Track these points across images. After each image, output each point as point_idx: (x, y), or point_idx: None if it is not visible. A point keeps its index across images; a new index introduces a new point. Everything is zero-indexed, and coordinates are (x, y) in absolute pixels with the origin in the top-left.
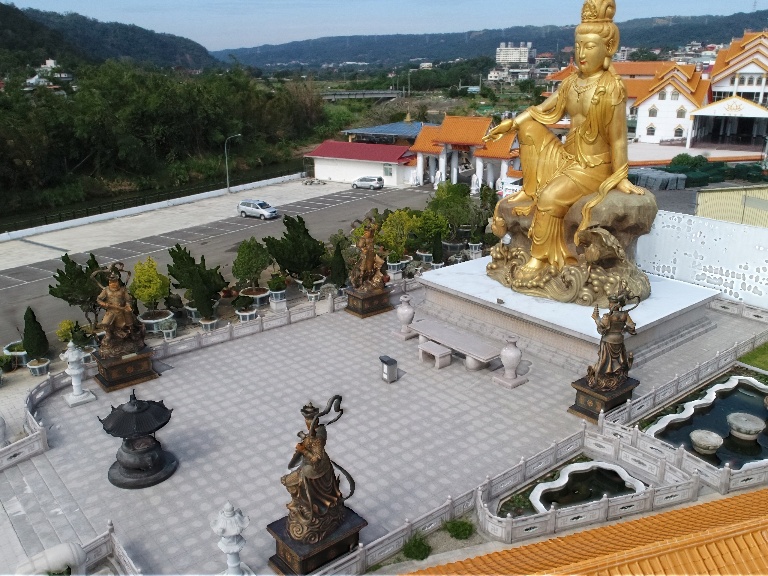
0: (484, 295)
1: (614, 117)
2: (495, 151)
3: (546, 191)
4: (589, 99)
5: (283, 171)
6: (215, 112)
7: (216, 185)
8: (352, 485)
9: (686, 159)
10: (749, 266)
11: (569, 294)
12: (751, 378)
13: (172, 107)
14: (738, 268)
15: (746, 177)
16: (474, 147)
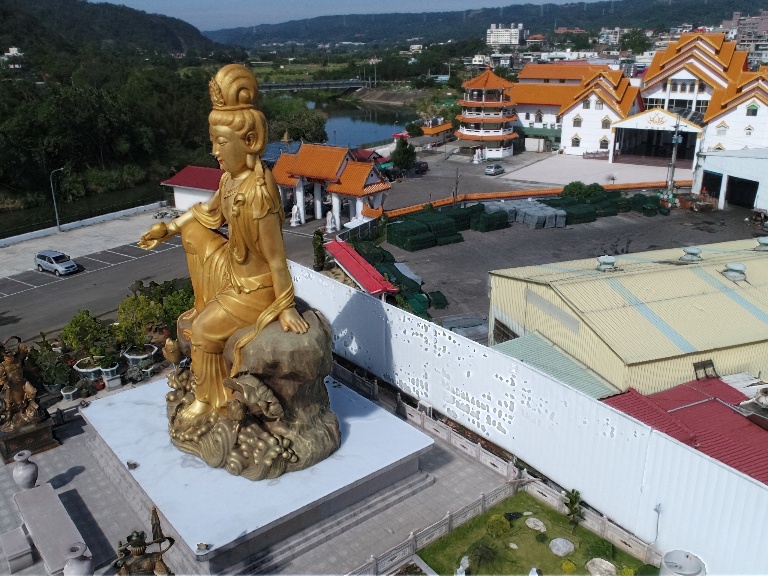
0: (126, 450)
1: (261, 233)
2: (348, 187)
3: (195, 321)
4: (230, 208)
5: (136, 201)
6: (120, 119)
7: (42, 224)
8: None
9: (578, 188)
10: (491, 397)
11: (217, 458)
12: None
13: (64, 116)
14: (481, 397)
15: (642, 210)
16: (328, 181)
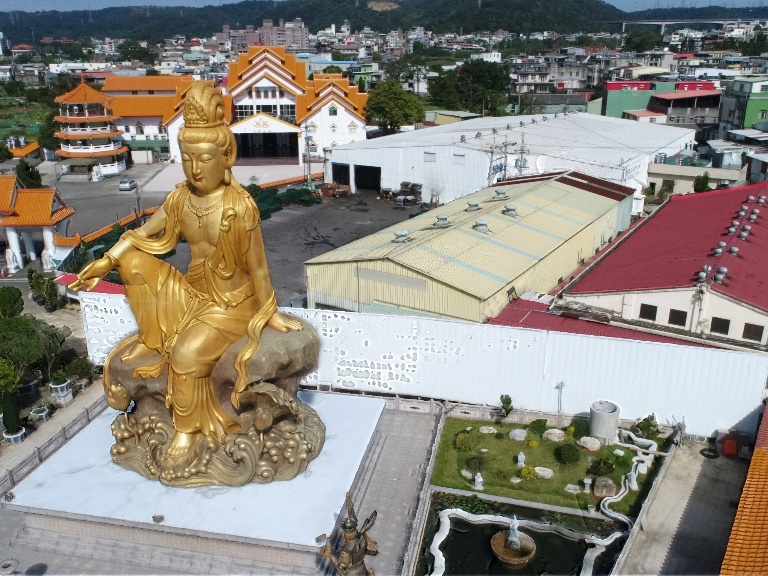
0: (128, 511)
1: (251, 244)
2: (30, 217)
3: (182, 349)
4: (216, 225)
5: None
6: None
7: None
8: None
9: None
10: (393, 356)
11: (244, 475)
12: (458, 510)
13: None
14: (383, 359)
15: (300, 202)
16: None
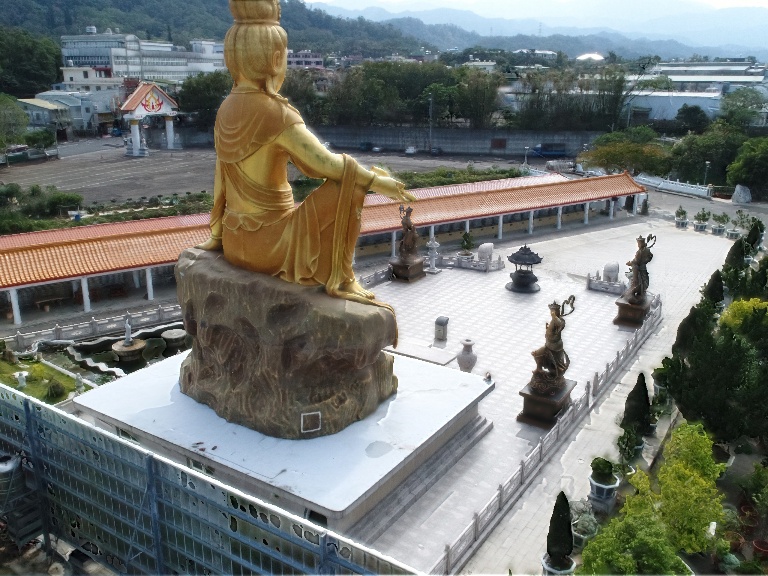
0: None
1: None
2: None
3: None
4: None
5: None
6: None
7: None
8: None
9: None
10: None
11: None
12: None
13: None
14: None
15: None
16: None
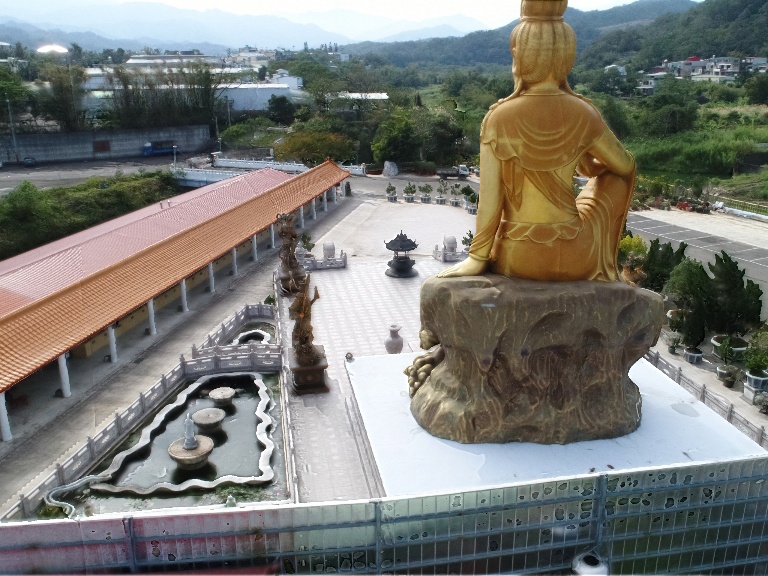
0: None
1: None
2: None
3: None
4: None
5: None
6: None
7: None
8: (288, 261)
9: None
10: (434, 572)
11: None
12: (254, 478)
13: None
14: None
15: None
16: None
